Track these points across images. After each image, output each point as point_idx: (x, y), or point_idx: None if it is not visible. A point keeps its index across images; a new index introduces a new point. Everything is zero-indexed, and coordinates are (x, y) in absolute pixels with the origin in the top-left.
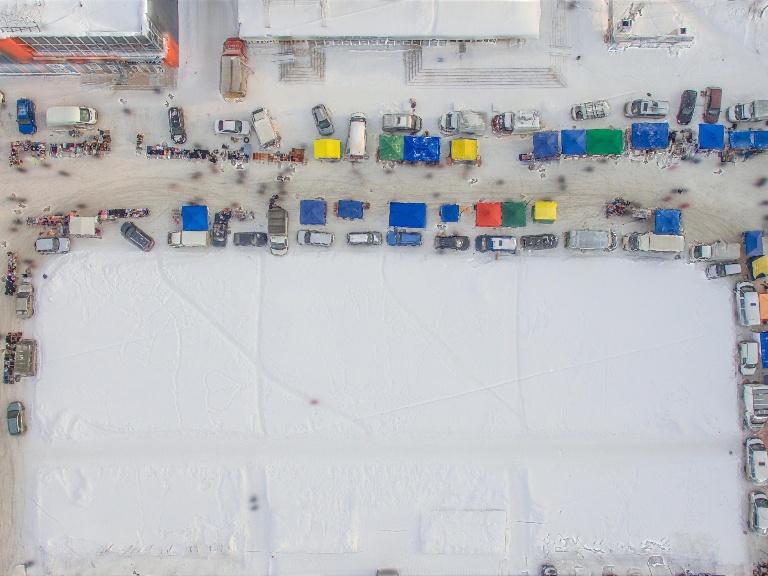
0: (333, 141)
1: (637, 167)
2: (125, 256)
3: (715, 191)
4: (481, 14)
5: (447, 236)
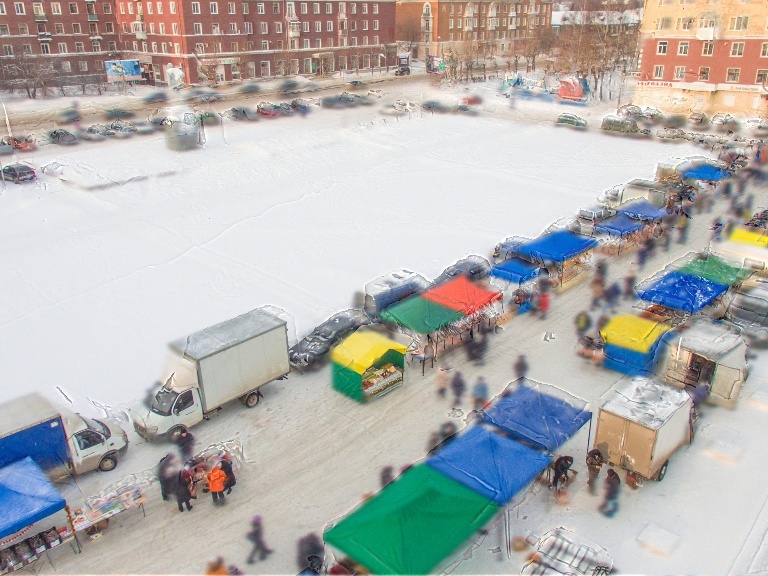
0: (758, 237)
1: None
2: None
3: None
4: None
5: (480, 274)
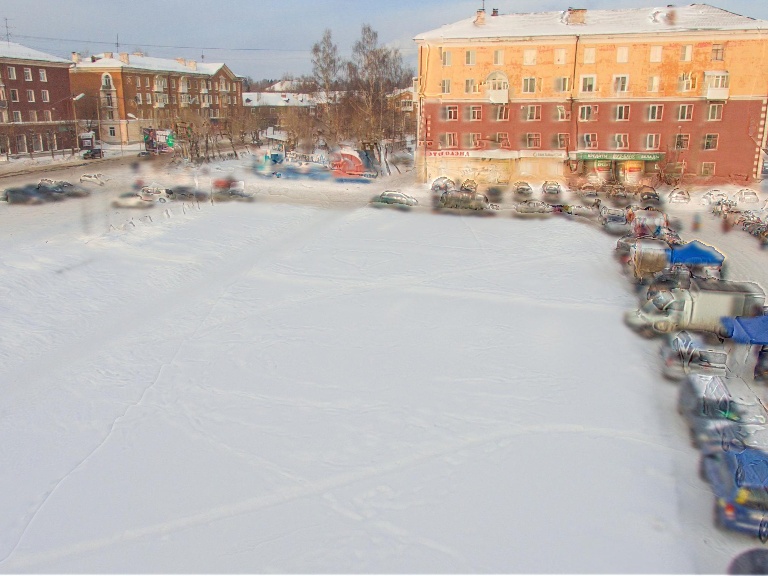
0: None
1: None
2: (606, 242)
3: None
4: None
5: None
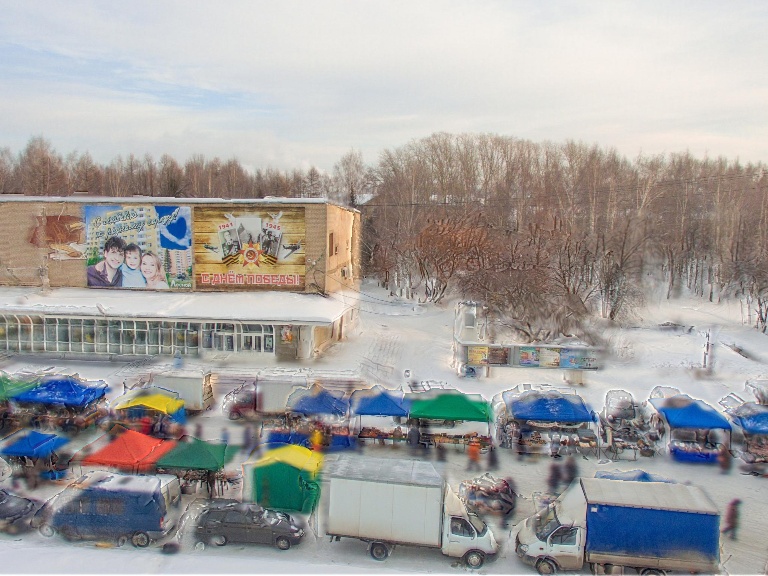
0: None
1: (535, 459)
2: None
3: (766, 495)
4: (251, 301)
5: None
